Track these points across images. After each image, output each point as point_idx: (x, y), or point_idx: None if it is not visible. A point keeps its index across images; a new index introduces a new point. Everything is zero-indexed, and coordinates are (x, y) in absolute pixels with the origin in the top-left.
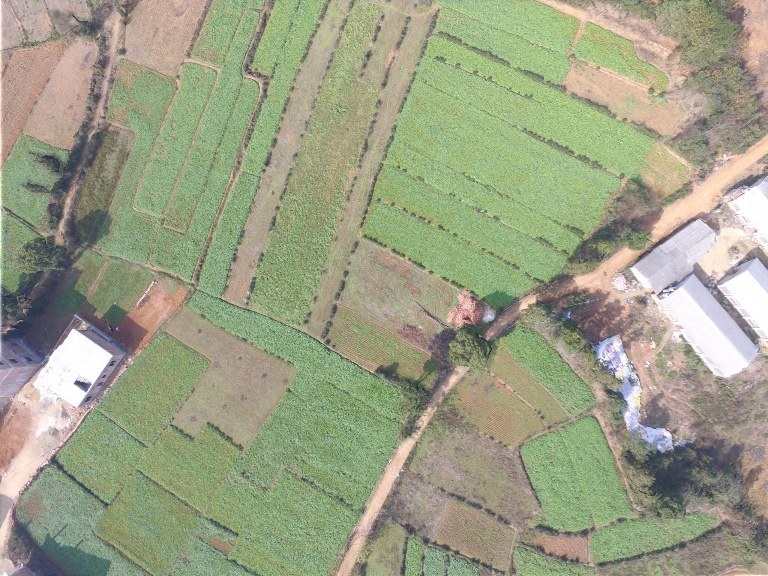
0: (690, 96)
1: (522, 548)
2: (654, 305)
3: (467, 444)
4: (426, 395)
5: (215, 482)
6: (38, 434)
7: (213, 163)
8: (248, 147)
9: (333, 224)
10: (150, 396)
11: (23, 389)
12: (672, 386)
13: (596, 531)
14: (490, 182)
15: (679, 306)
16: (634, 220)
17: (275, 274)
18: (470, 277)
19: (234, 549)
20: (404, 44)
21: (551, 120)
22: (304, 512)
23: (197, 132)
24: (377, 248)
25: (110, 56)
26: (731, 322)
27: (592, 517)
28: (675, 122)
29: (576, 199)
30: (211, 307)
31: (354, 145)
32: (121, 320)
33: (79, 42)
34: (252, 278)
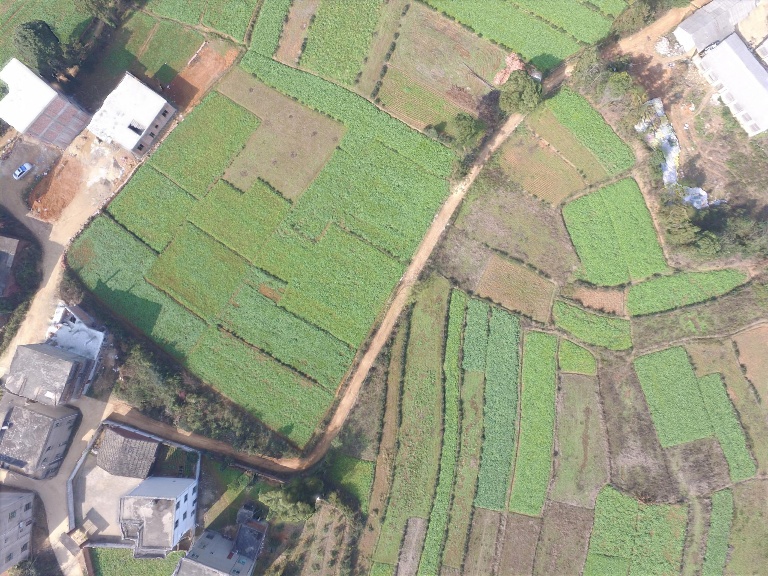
0: None
1: (561, 302)
2: (695, 69)
3: (511, 202)
4: (473, 153)
5: (265, 233)
6: (89, 185)
7: None
8: None
9: None
10: (201, 150)
11: (74, 141)
12: (709, 148)
13: (632, 286)
14: None
15: (720, 61)
16: None
17: (327, 35)
18: (518, 40)
19: (283, 296)
20: None
21: None
22: (352, 263)
23: None
24: (428, 11)
25: None
26: None
27: (629, 272)
28: None
29: None
30: (263, 66)
31: None
32: (172, 79)
33: None
34: (304, 39)
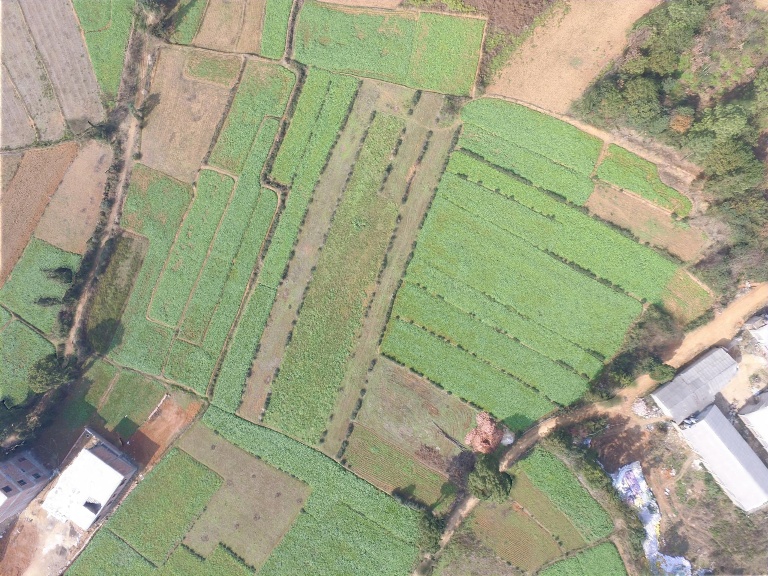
0: (713, 223)
1: None
2: (674, 432)
3: (484, 569)
4: (443, 519)
5: None
6: (45, 552)
7: (229, 274)
8: (265, 259)
9: (351, 340)
10: (161, 514)
11: (30, 505)
12: (691, 514)
13: None
14: (511, 303)
15: (701, 438)
16: (656, 347)
17: (291, 390)
18: (489, 399)
19: None
20: (425, 159)
21: (573, 242)
22: None
23: (213, 241)
24: (395, 366)
25: (125, 160)
26: (752, 455)
27: None
28: (698, 248)
29: (597, 323)
30: (225, 423)
31: (373, 260)
32: (132, 434)
33: (93, 144)
34: (267, 394)
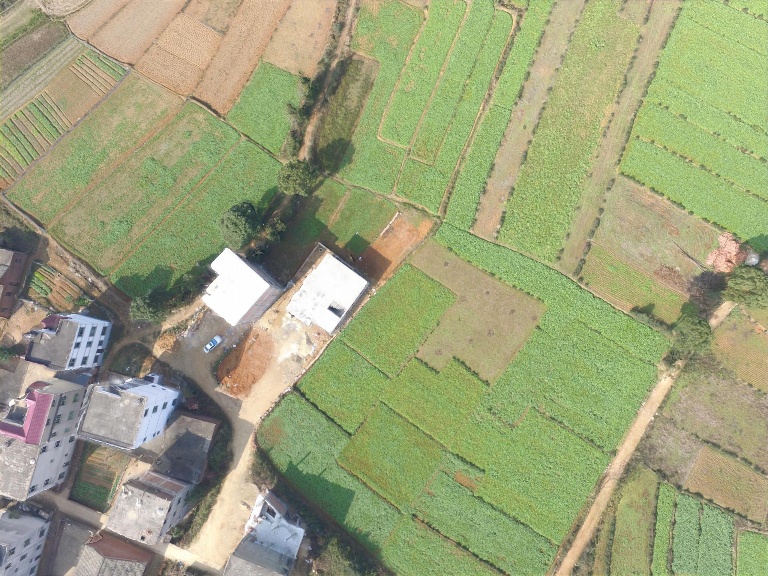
0: None
1: None
2: None
3: (723, 391)
4: (684, 338)
5: (461, 417)
6: (280, 360)
7: (462, 95)
8: (500, 80)
9: (588, 160)
10: (395, 327)
11: (265, 314)
12: None
13: None
14: (758, 122)
15: None
16: None
17: (526, 209)
18: (733, 219)
19: (481, 486)
20: None
21: None
22: (553, 452)
23: (446, 63)
24: (634, 186)
25: None
26: None
27: None
28: None
29: None
30: (459, 240)
31: (612, 81)
32: (364, 250)
33: None
34: (502, 212)
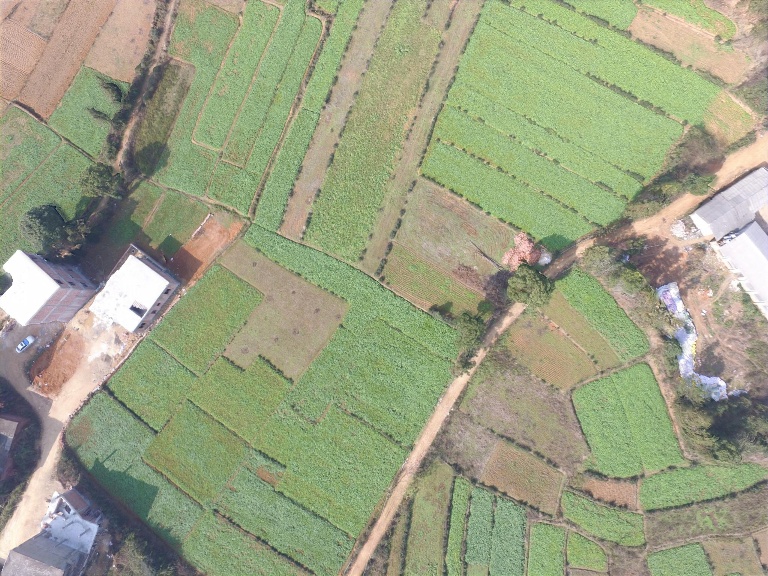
0: (757, 44)
1: (570, 492)
2: (713, 253)
3: (518, 386)
4: (479, 335)
5: (265, 414)
6: (90, 360)
7: (273, 99)
8: (309, 84)
9: (391, 163)
10: (203, 326)
11: (77, 315)
12: (728, 335)
13: (646, 478)
14: (551, 125)
15: (740, 252)
16: (696, 167)
17: (332, 210)
18: (527, 219)
19: (282, 481)
20: None
21: (615, 65)
22: (353, 447)
23: (258, 68)
24: (435, 188)
25: None
26: None
27: (642, 464)
28: (741, 70)
29: (637, 144)
30: (266, 241)
31: (415, 85)
32: (176, 251)
33: None
34: (308, 213)
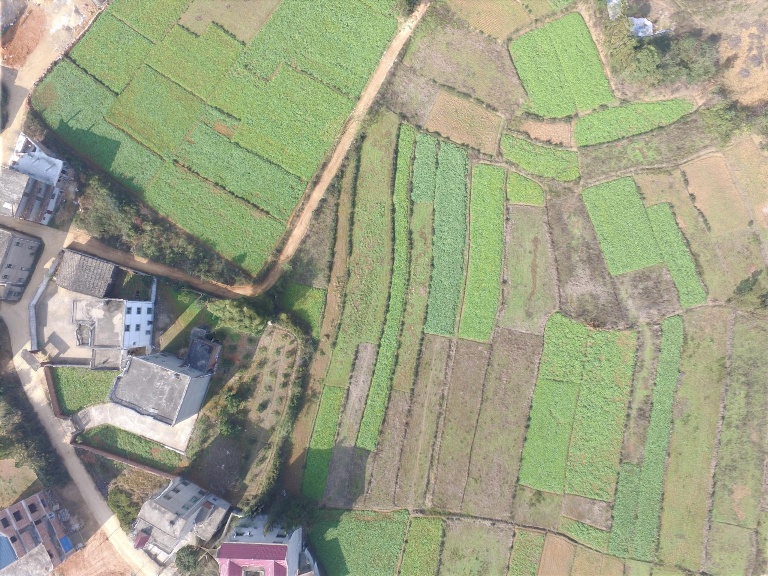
0: None
1: (509, 135)
2: None
3: (458, 39)
4: None
5: (219, 73)
6: (52, 32)
7: None
8: None
9: None
10: None
11: None
12: None
13: (579, 118)
14: None
15: None
16: None
17: None
18: None
19: (237, 133)
20: None
21: None
22: (303, 101)
23: None
24: None
25: None
26: None
27: (575, 104)
28: None
29: None
30: None
31: None
32: None
33: None
34: None
